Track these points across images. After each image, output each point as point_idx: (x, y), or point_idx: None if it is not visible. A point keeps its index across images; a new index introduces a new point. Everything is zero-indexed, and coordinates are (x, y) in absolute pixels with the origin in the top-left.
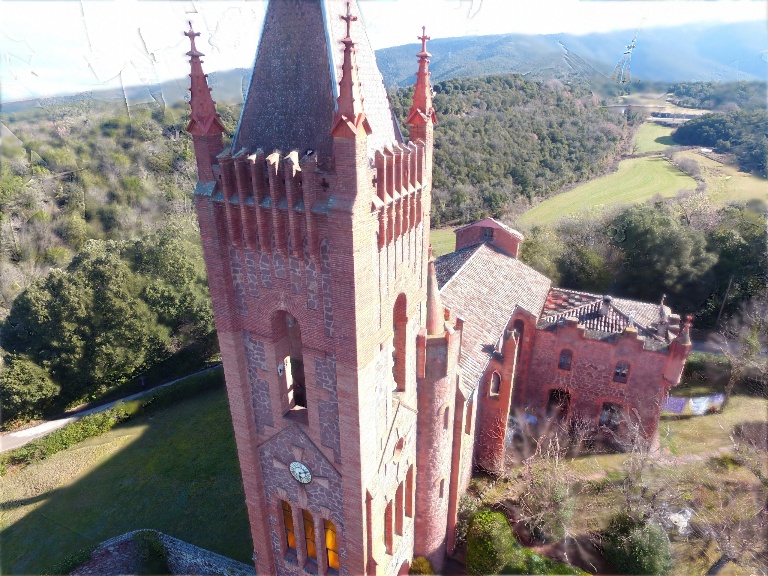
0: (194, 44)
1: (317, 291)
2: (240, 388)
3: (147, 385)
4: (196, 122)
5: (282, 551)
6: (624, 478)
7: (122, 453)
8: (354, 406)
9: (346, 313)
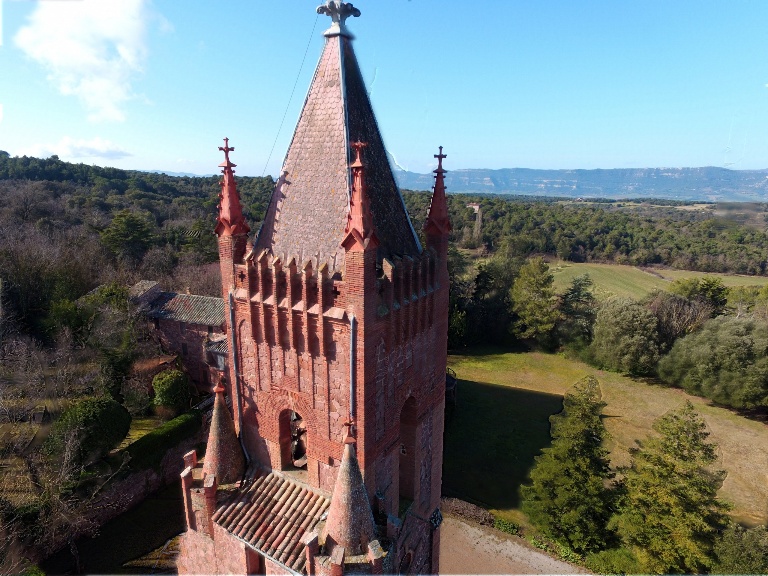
0: (439, 164)
1: None
2: None
3: None
4: None
5: None
6: None
7: None
8: None
9: None
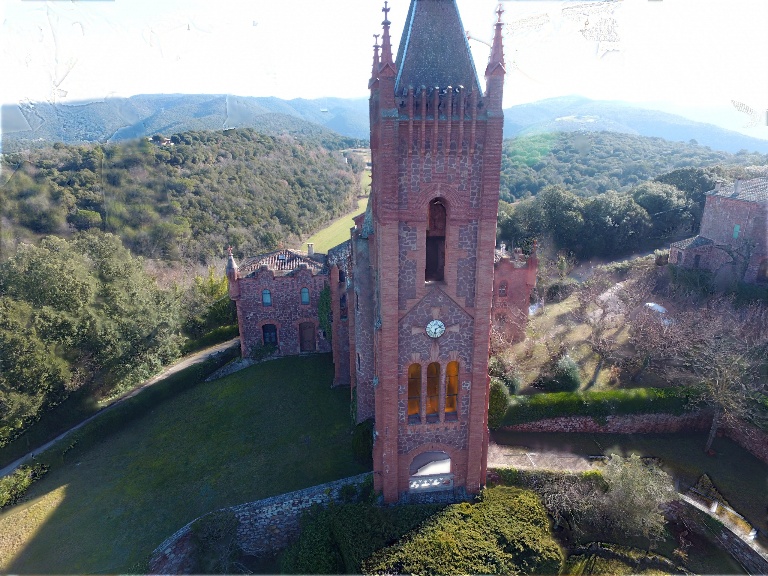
0: None
1: (467, 177)
2: (397, 269)
3: (33, 444)
4: (389, 67)
5: (407, 417)
6: (525, 355)
7: (75, 499)
8: (492, 250)
9: (493, 184)
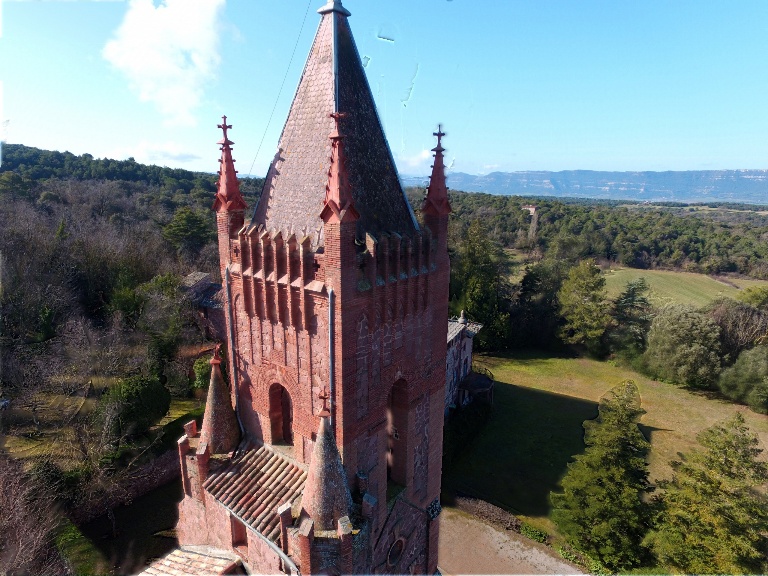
0: (438, 142)
1: None
2: None
3: None
4: None
5: None
6: None
7: None
8: None
9: None
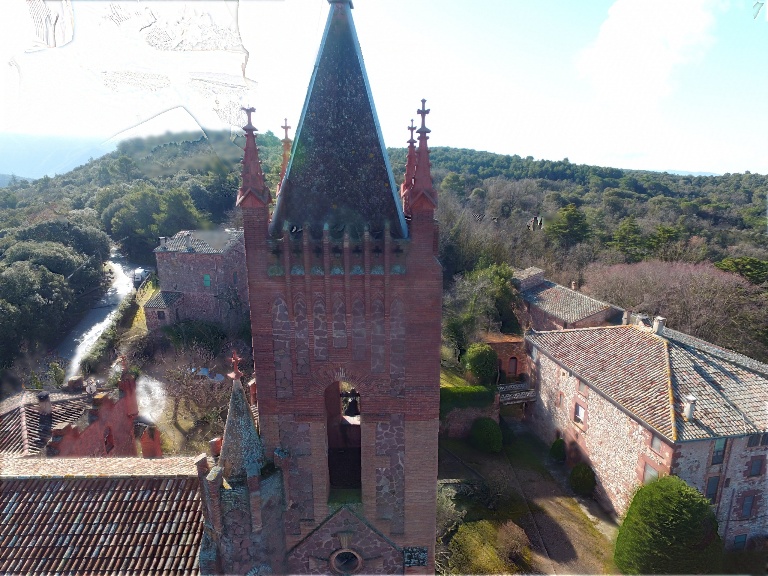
0: (423, 121)
1: None
2: None
3: None
4: None
5: None
6: None
7: None
8: None
9: None
